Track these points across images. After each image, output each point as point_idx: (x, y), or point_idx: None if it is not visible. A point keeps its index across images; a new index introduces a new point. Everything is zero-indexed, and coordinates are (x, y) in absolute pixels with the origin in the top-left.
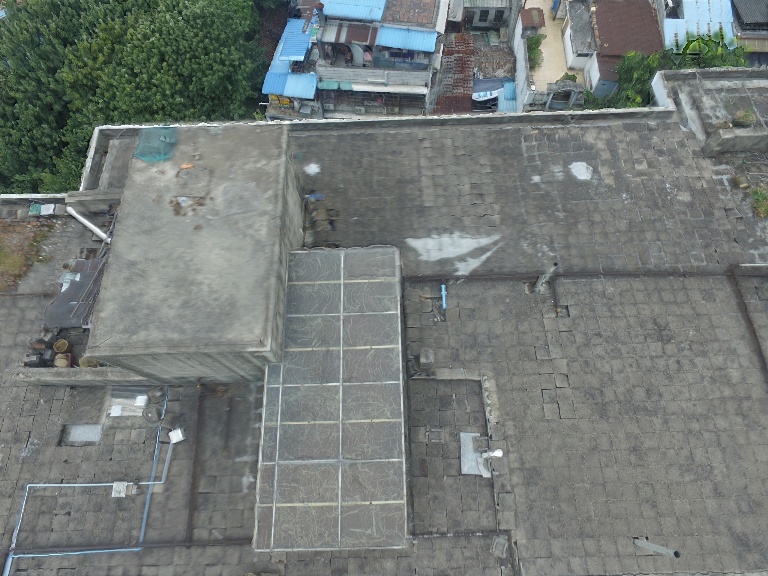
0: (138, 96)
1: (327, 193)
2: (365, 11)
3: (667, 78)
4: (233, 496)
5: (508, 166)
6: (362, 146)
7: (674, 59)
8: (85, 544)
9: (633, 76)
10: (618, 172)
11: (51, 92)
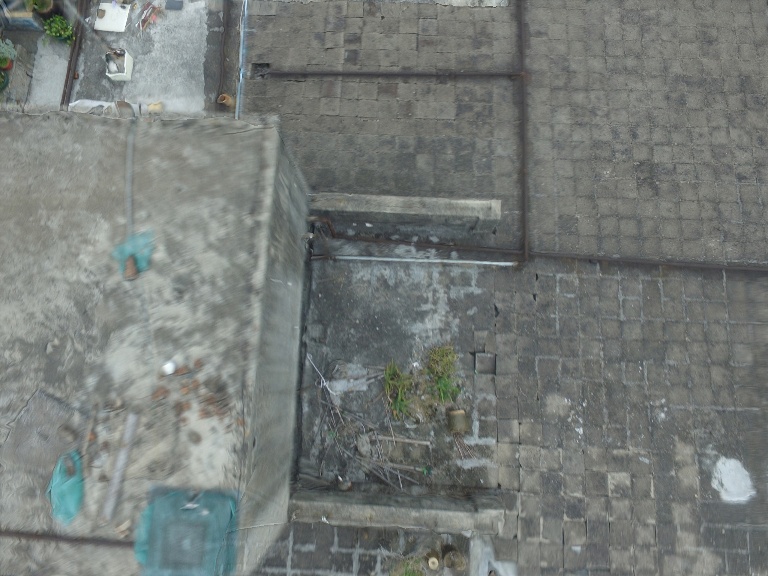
0: None
1: None
2: None
3: None
4: None
5: None
6: None
7: None
8: None
9: None
10: (665, 469)
11: None
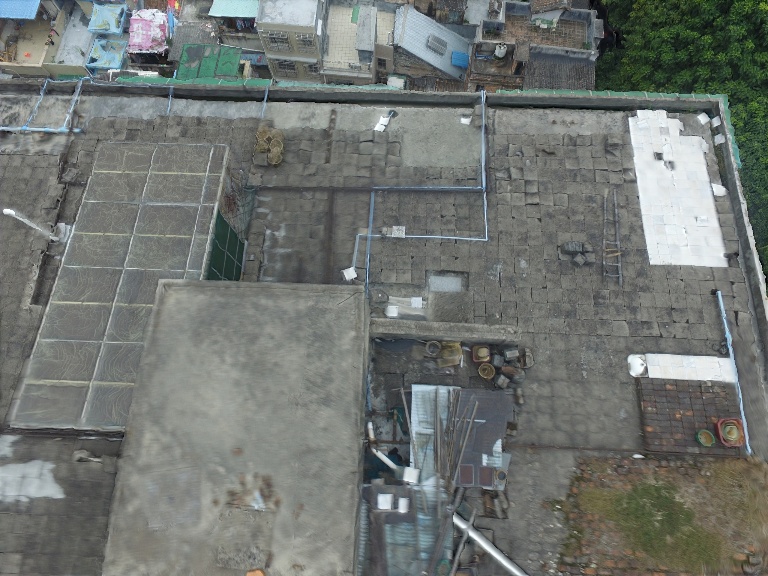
0: None
1: None
2: None
3: None
4: (294, 222)
5: None
6: None
7: None
8: (421, 193)
9: None
10: None
11: None
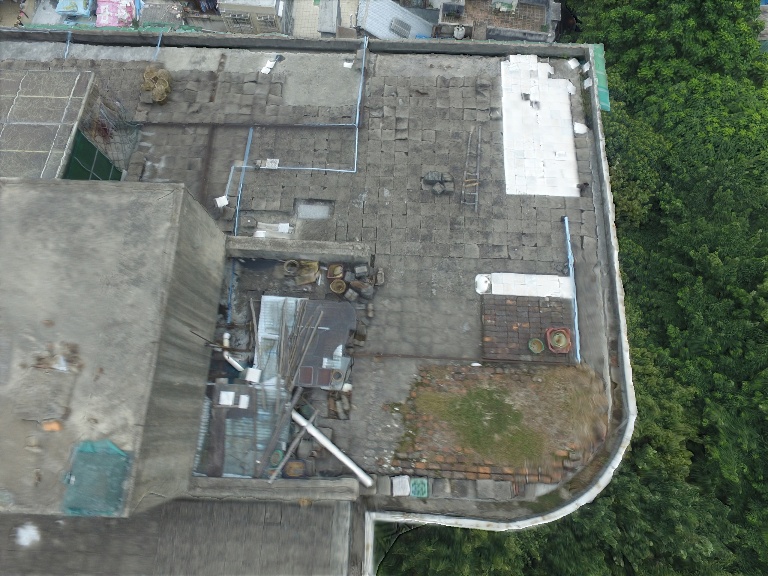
0: None
1: None
2: None
3: None
4: (174, 154)
5: None
6: None
7: None
8: (297, 129)
9: None
10: None
11: None
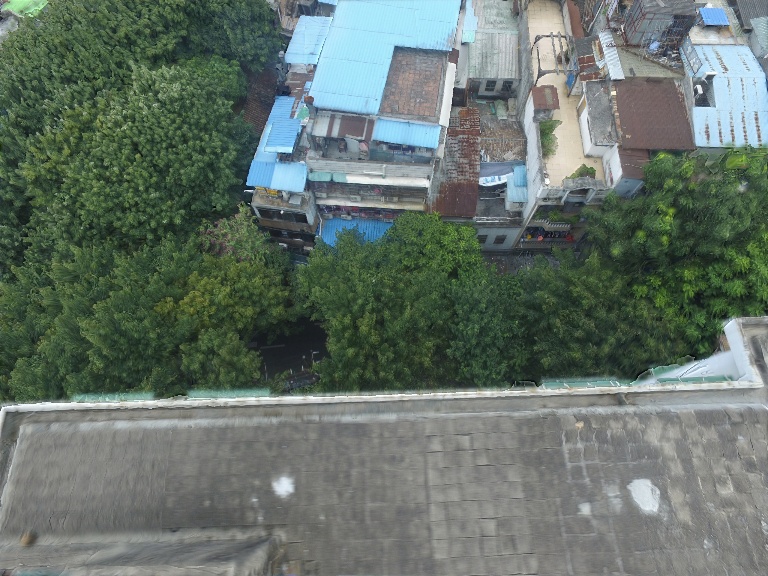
0: (108, 194)
1: (303, 531)
2: (360, 103)
3: (745, 326)
4: None
5: (546, 485)
6: (351, 447)
7: (704, 151)
8: None
9: (663, 186)
10: (694, 498)
11: (12, 187)
